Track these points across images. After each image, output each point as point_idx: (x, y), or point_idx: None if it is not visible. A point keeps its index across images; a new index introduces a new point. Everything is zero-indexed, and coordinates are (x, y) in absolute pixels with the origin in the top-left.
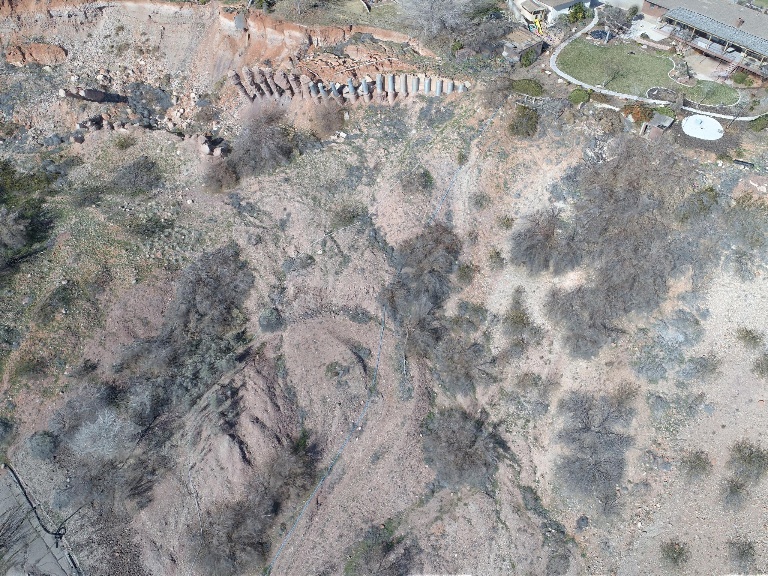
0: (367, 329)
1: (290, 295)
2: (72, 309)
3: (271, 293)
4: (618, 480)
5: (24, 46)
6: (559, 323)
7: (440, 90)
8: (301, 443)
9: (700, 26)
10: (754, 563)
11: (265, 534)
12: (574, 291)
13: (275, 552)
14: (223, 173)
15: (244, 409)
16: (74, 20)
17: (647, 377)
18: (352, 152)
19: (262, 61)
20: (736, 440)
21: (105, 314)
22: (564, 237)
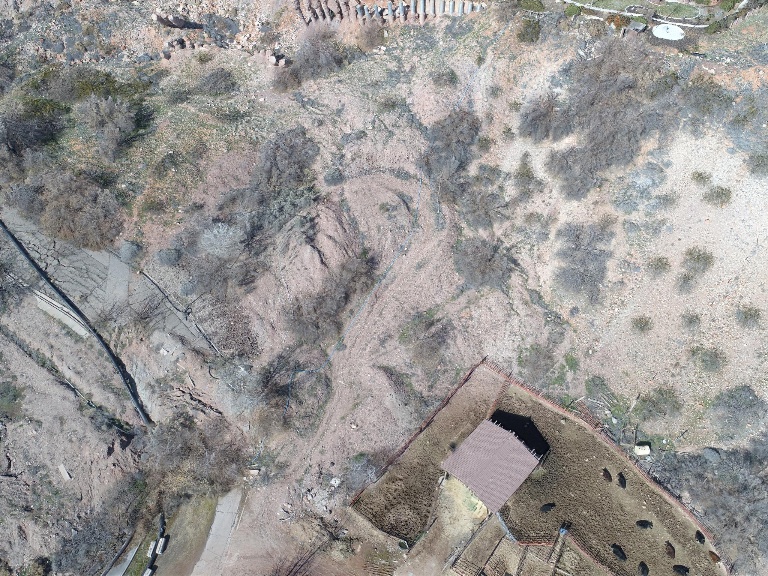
0: (408, 183)
1: (348, 159)
2: (180, 169)
3: (333, 159)
4: (601, 281)
5: None
6: (557, 176)
7: (462, 11)
8: (362, 257)
9: None
10: (700, 328)
11: (338, 316)
12: (568, 151)
13: (346, 328)
14: (288, 77)
15: (320, 230)
16: None
17: (623, 210)
18: (391, 60)
19: None
20: (688, 248)
21: (205, 173)
22: None
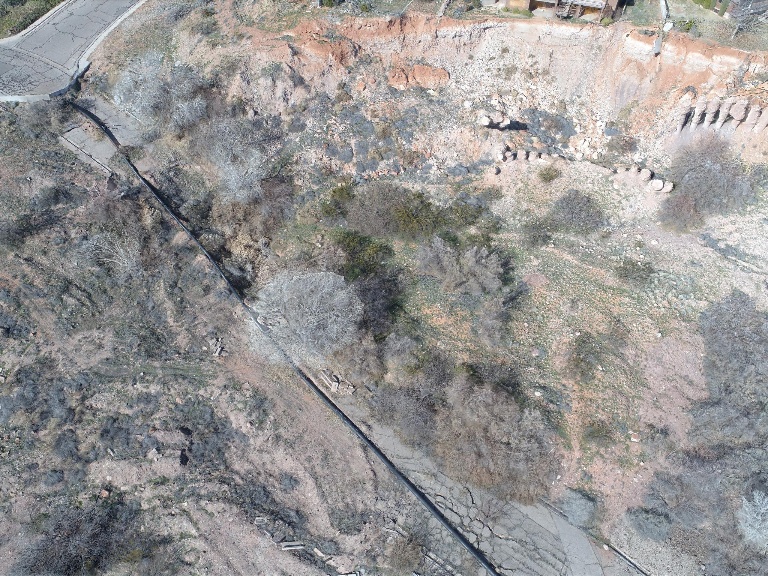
0: None
1: None
2: (606, 365)
3: None
4: None
5: (407, 68)
6: None
7: None
8: None
9: None
10: None
11: None
12: None
13: None
14: (692, 212)
15: None
16: (458, 41)
17: None
18: None
19: (681, 88)
20: None
21: (640, 371)
22: None
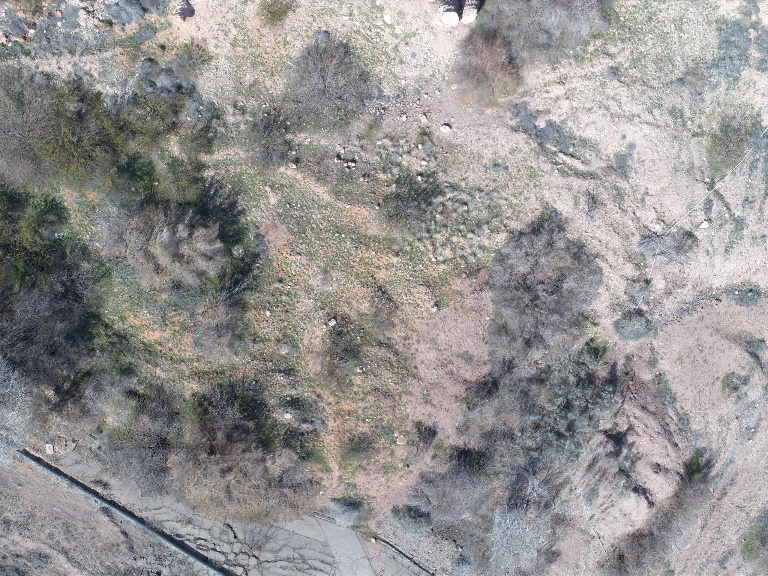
0: (759, 312)
1: (659, 290)
2: (367, 363)
3: (628, 288)
4: None
5: None
6: None
7: None
8: (694, 462)
9: None
10: None
11: None
12: None
13: None
14: (500, 74)
15: (640, 457)
16: None
17: None
18: None
19: None
20: None
21: (410, 357)
22: None
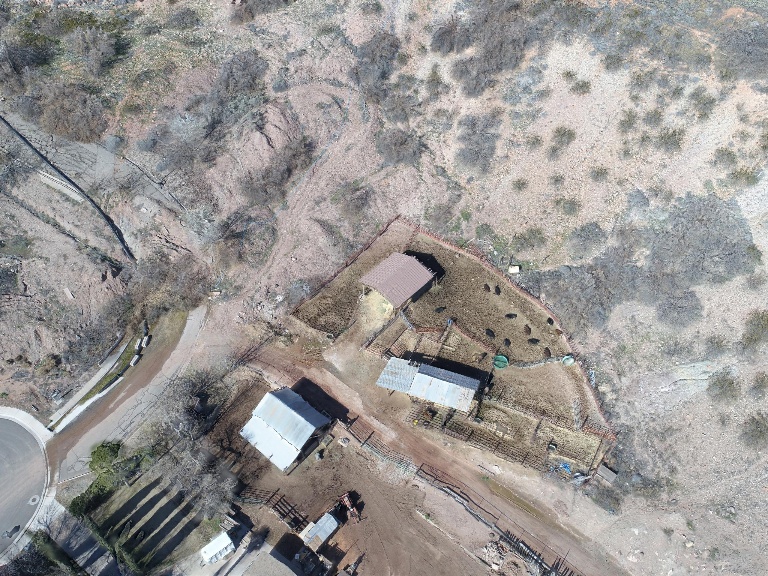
0: (341, 90)
1: (292, 72)
2: (153, 81)
3: (280, 72)
4: (491, 156)
5: None
6: (460, 81)
7: None
8: None
9: None
10: (563, 185)
11: (283, 186)
12: (468, 60)
13: (289, 194)
14: (243, 11)
15: (267, 122)
16: None
17: (510, 103)
18: None
19: None
20: (557, 127)
21: (174, 85)
22: (463, 30)
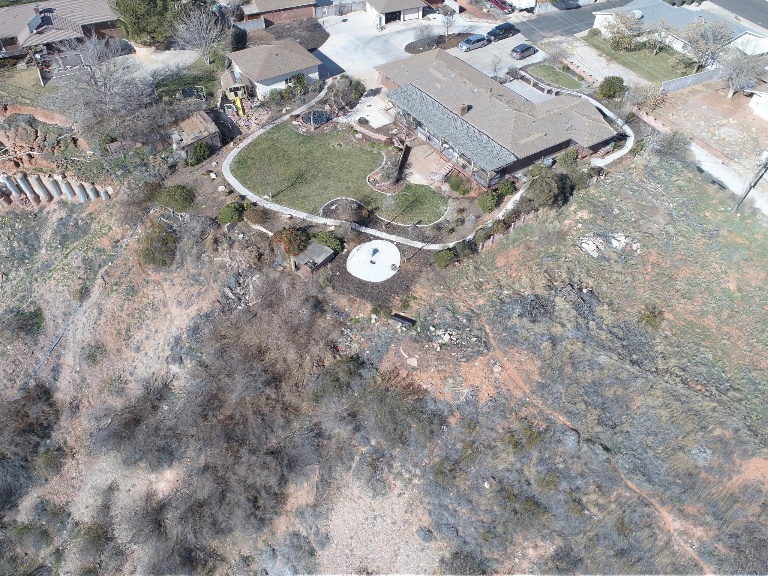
0: None
1: None
2: None
3: None
4: None
5: None
6: (148, 541)
7: (84, 195)
8: None
9: (416, 113)
10: None
11: None
12: (166, 498)
13: None
14: None
15: None
16: None
17: None
18: None
19: None
20: None
21: None
22: (167, 418)
